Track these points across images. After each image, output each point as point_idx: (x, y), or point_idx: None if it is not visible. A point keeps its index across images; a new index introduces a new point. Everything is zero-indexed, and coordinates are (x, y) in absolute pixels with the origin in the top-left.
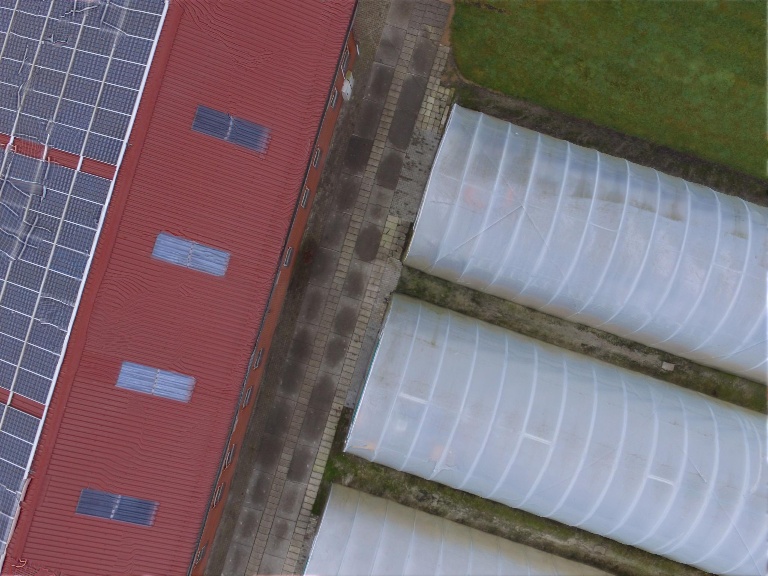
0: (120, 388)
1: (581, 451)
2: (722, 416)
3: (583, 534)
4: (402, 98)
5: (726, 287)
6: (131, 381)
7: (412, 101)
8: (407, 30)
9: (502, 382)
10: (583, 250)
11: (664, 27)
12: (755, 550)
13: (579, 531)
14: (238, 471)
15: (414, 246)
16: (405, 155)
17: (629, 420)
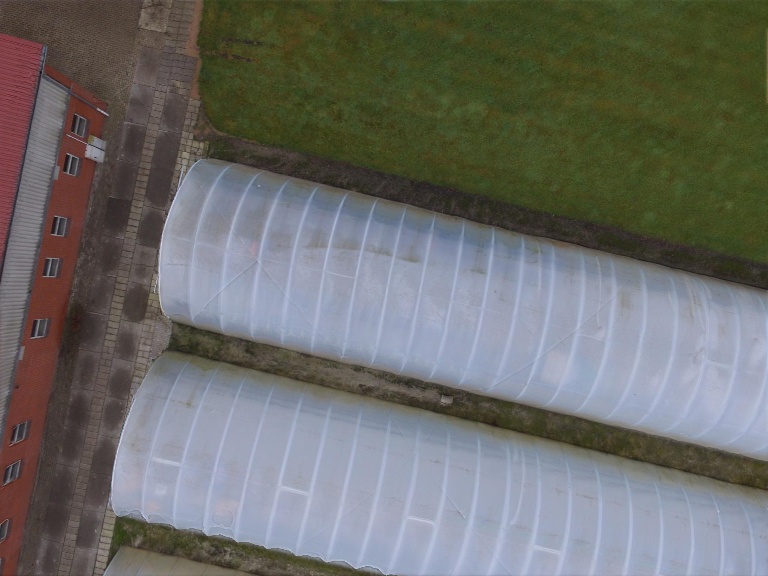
0: None
1: (338, 499)
2: (492, 447)
3: (378, 573)
4: (156, 156)
5: (468, 324)
6: None
7: (166, 158)
8: (155, 87)
9: (257, 437)
10: (324, 299)
11: (414, 63)
12: None
13: (373, 570)
14: (26, 543)
15: (165, 307)
16: (165, 212)
17: (388, 463)
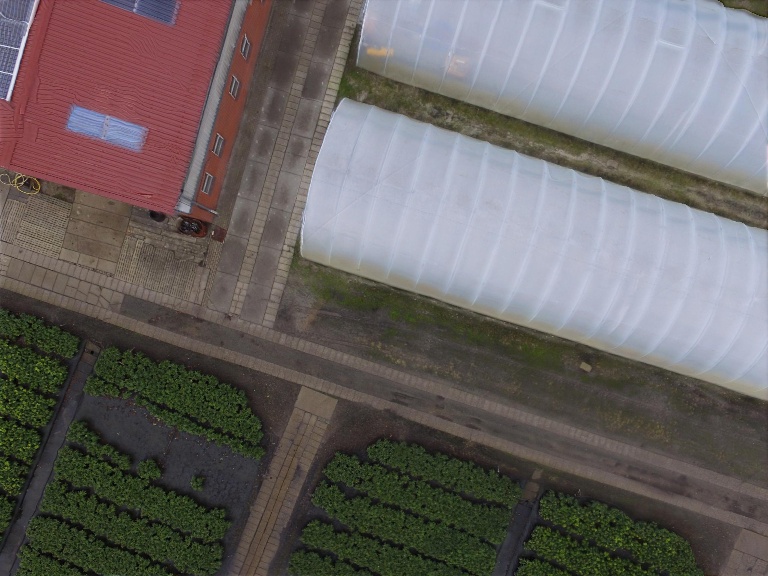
0: None
1: (593, 14)
2: (728, 9)
3: (596, 148)
4: None
5: None
6: None
7: None
8: None
9: None
10: None
11: None
12: (765, 114)
13: (592, 145)
14: (253, 90)
15: None
16: None
17: None
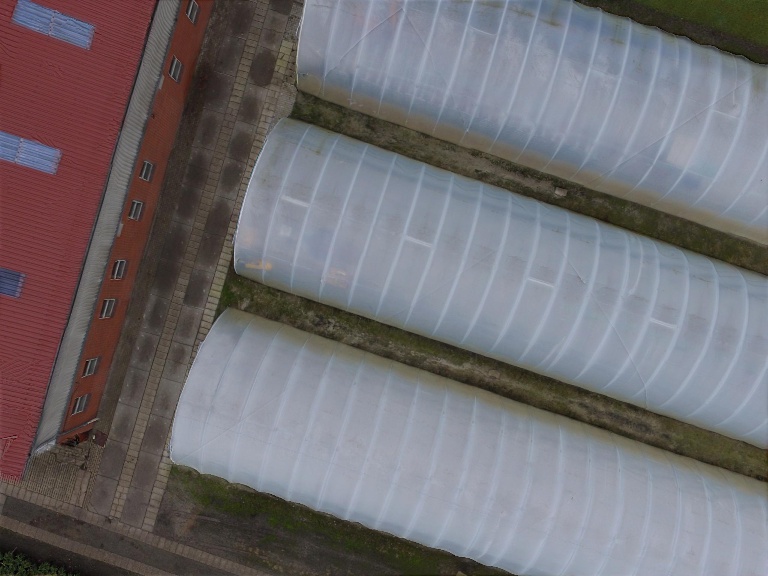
0: None
1: (462, 253)
2: (608, 231)
3: (478, 358)
4: None
5: (604, 90)
6: None
7: None
8: None
9: (385, 187)
10: (464, 54)
11: None
12: (634, 352)
13: (474, 355)
14: (135, 296)
15: (301, 58)
16: None
17: (511, 226)
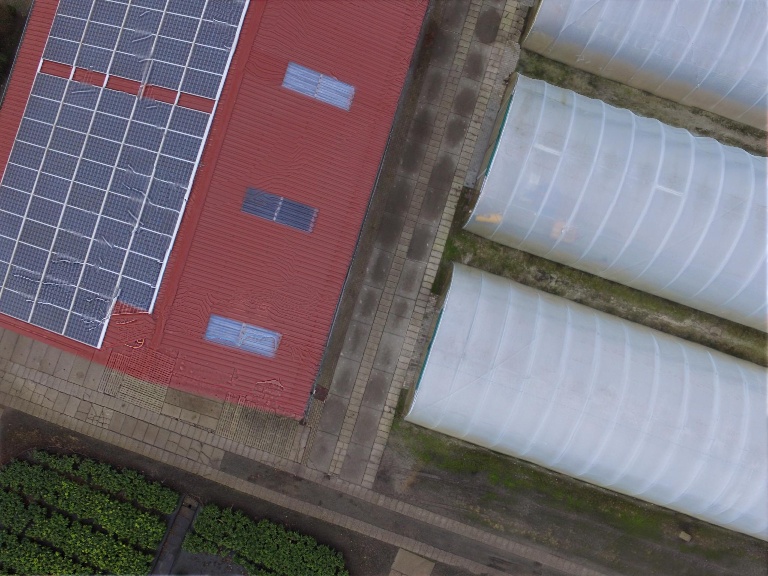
0: (284, 90)
1: (713, 202)
2: None
3: (699, 315)
4: None
5: None
6: (295, 83)
7: None
8: None
9: (633, 137)
10: (712, 7)
11: None
12: None
13: (695, 312)
14: (358, 250)
15: (542, 12)
16: None
17: (757, 177)
